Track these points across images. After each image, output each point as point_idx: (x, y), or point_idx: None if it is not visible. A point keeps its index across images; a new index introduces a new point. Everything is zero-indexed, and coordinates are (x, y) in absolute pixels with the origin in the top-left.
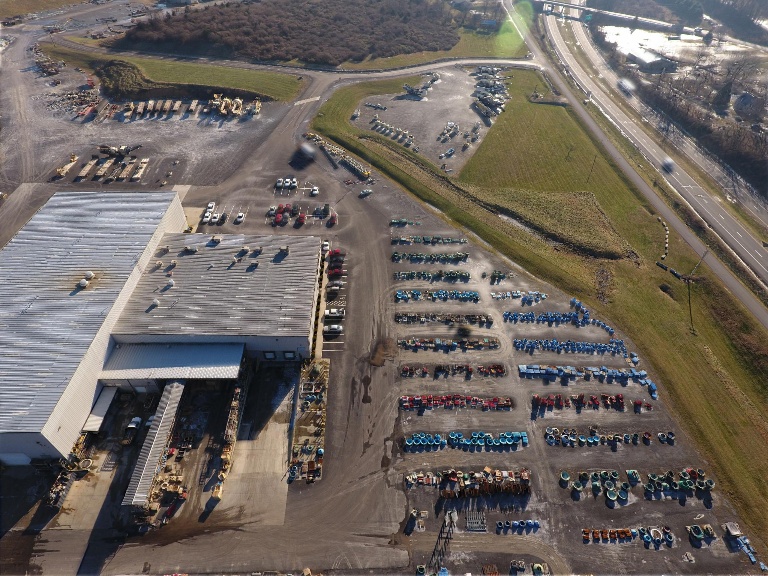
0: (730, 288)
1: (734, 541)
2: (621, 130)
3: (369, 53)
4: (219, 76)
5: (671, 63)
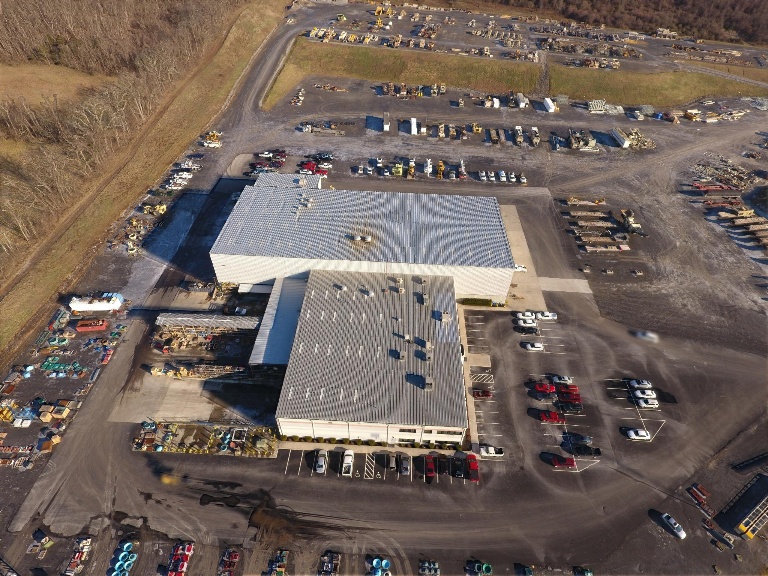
0: None
1: None
2: None
3: None
4: None
5: None
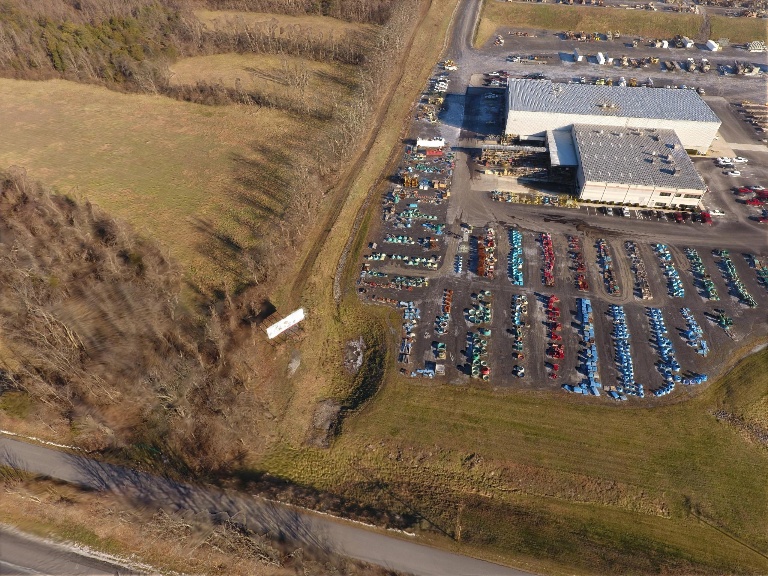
0: None
1: (432, 367)
2: None
3: None
4: None
5: None
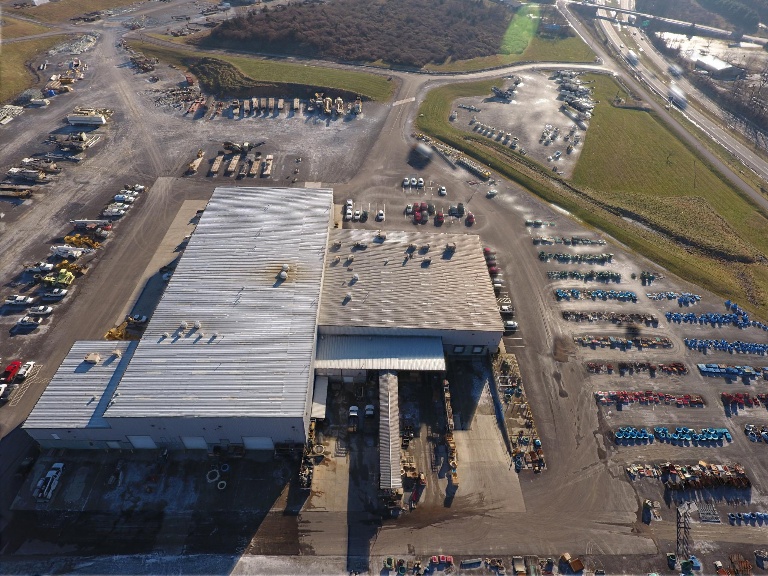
0: None
1: None
2: (711, 136)
3: (448, 55)
4: (314, 75)
5: (741, 70)
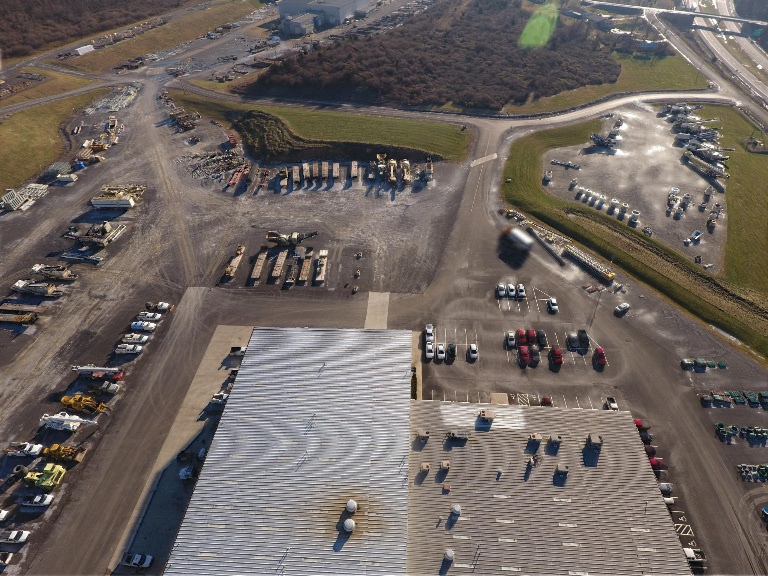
0: None
1: None
2: None
3: (530, 91)
4: (374, 129)
5: None
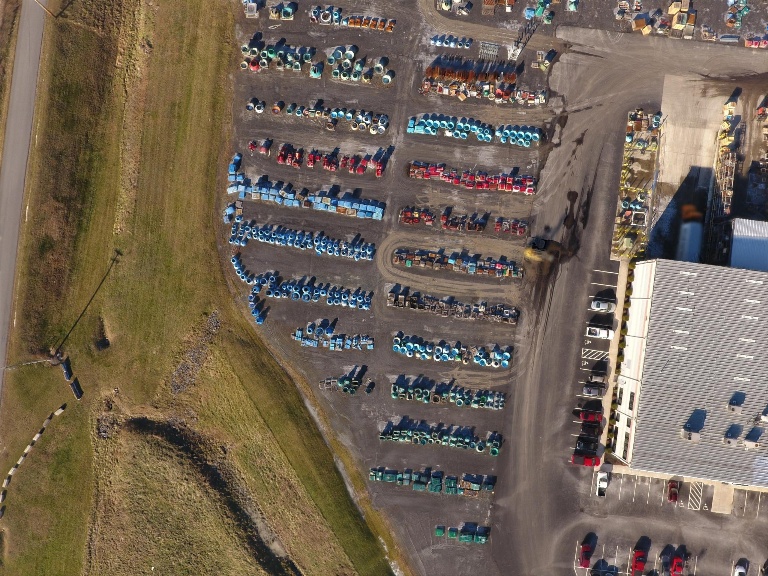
0: (8, 323)
1: (257, 2)
2: None
3: None
4: None
5: None
